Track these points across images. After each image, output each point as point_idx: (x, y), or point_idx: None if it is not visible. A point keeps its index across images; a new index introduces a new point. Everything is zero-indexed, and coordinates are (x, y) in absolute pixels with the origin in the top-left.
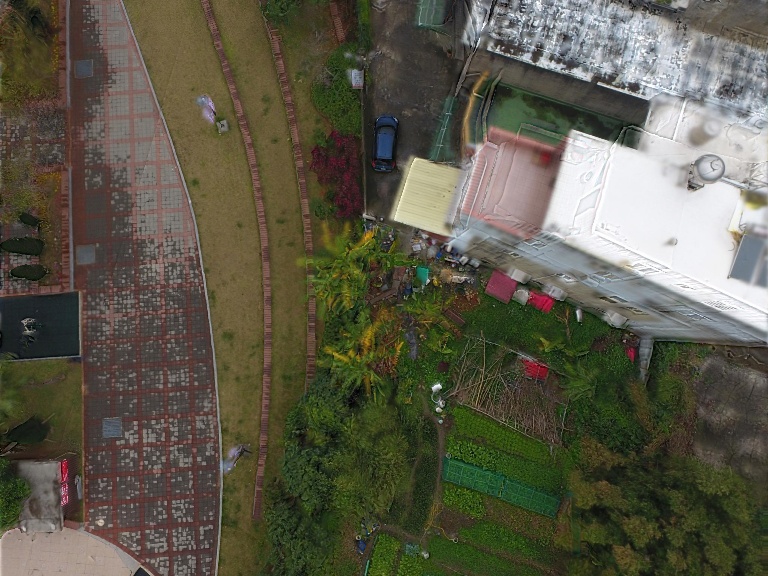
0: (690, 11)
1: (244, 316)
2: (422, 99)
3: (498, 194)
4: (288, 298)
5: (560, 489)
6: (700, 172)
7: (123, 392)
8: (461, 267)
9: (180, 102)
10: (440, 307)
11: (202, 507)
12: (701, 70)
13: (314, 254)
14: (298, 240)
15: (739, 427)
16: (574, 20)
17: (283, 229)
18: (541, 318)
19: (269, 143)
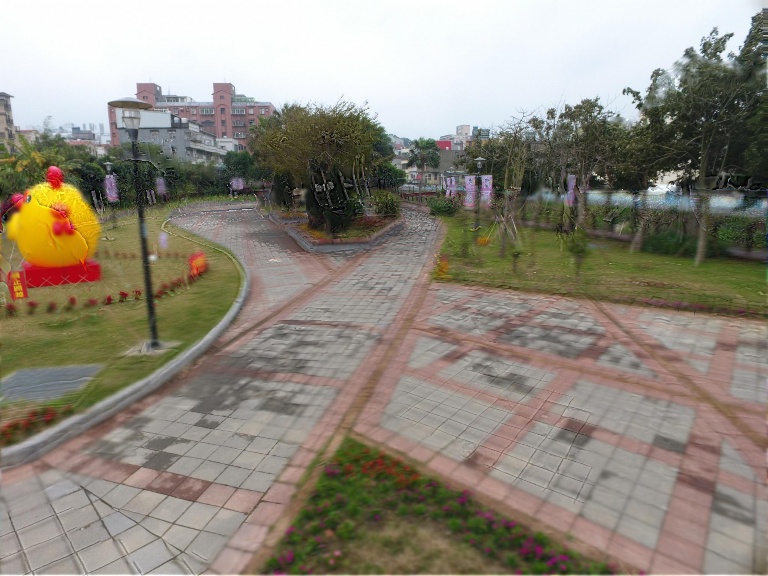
0: None
1: None
2: None
3: None
4: None
5: None
6: None
7: None
8: None
9: None
10: None
11: None
12: None
13: None
14: None
15: None
16: None
17: None
18: None
19: None
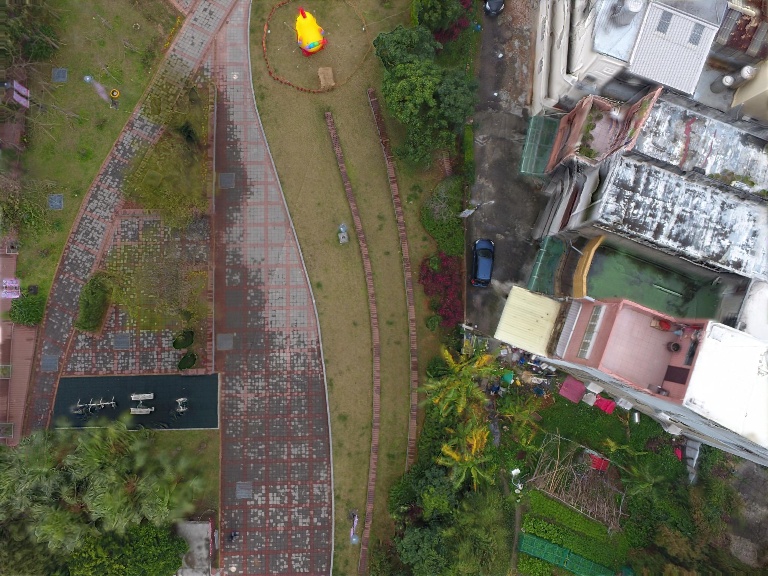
0: (759, 207)
1: (356, 401)
2: (514, 223)
3: (600, 351)
4: (394, 388)
5: (614, 562)
6: (767, 361)
7: (254, 461)
8: (541, 370)
9: (308, 214)
10: (528, 411)
11: (316, 560)
12: (765, 256)
13: (418, 353)
14: (404, 339)
15: (765, 517)
16: (666, 210)
17: (392, 329)
18: (605, 417)
19: (382, 254)
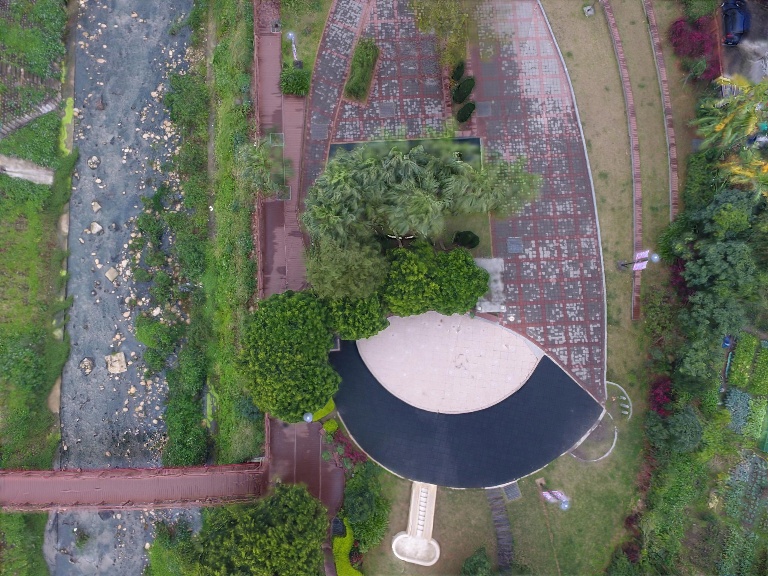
0: None
1: (615, 160)
2: None
3: None
4: (651, 146)
5: None
6: None
7: (522, 218)
8: None
9: None
10: None
11: (590, 309)
12: None
13: (672, 111)
14: (656, 101)
15: None
16: None
17: (644, 92)
18: None
19: (628, 24)
